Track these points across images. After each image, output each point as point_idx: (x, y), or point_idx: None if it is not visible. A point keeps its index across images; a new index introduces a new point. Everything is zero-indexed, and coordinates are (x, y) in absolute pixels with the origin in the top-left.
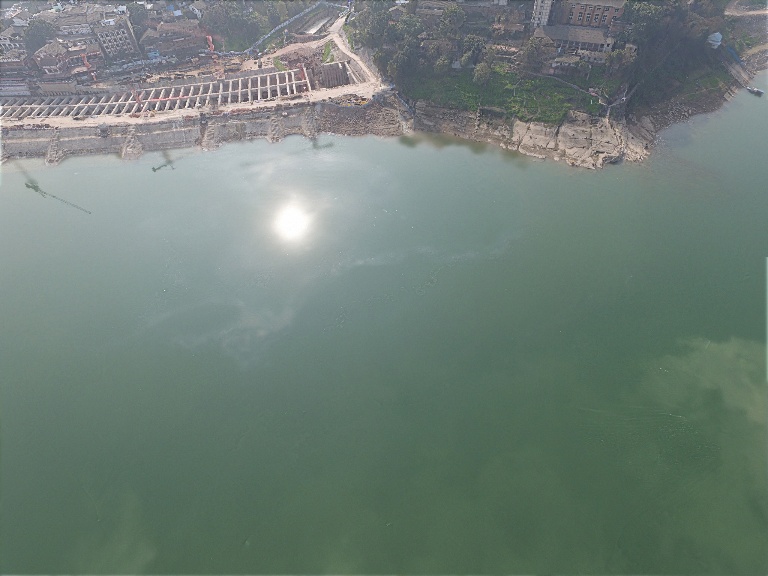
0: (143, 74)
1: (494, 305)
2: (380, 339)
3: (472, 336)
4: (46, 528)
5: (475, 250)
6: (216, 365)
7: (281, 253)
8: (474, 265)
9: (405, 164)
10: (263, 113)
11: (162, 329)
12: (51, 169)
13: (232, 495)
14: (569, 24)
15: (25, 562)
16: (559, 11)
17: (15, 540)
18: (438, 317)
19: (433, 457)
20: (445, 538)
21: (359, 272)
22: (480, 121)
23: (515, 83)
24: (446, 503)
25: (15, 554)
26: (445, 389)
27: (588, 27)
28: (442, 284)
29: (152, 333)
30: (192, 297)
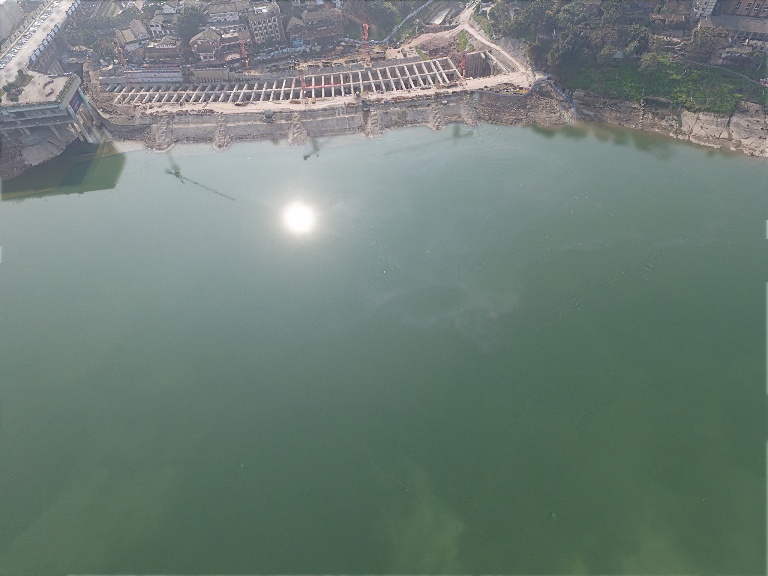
0: (290, 62)
1: (724, 291)
2: (615, 322)
3: (713, 320)
4: (348, 497)
5: (684, 237)
6: (463, 344)
7: (485, 237)
8: (688, 251)
9: (579, 152)
10: (423, 101)
11: (398, 309)
12: (222, 154)
13: (534, 469)
14: (736, 14)
15: (340, 529)
16: (728, 1)
17: (324, 508)
18: (671, 301)
19: (715, 436)
20: (753, 515)
21: (571, 257)
22: (644, 111)
23: (680, 73)
24: (742, 481)
25: (328, 521)
26: (702, 371)
27: (756, 17)
28: (663, 269)
29: (389, 312)
30: (414, 279)
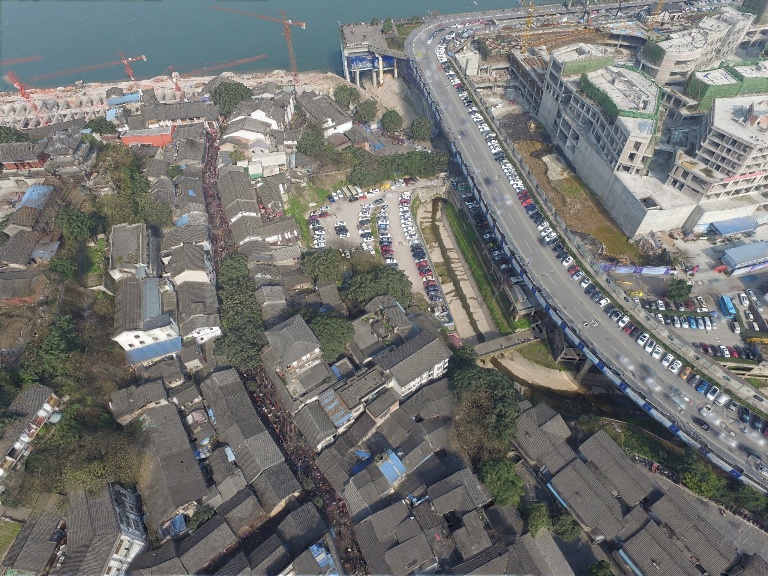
0: None
1: None
2: (41, 15)
3: None
4: None
5: None
6: None
7: (69, 34)
8: None
9: None
10: None
11: (135, 7)
12: (227, 71)
13: None
14: None
15: None
16: None
17: None
18: (8, 16)
19: None
20: None
21: (32, 30)
22: None
23: None
24: None
25: None
26: (27, 4)
27: None
28: None
29: (141, 7)
30: None
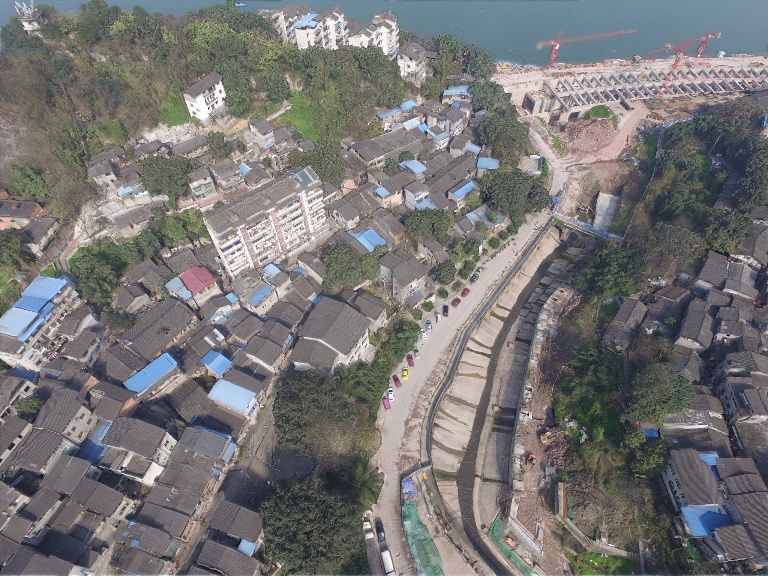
0: None
1: None
2: None
3: None
4: None
5: None
6: None
7: (516, 13)
8: (411, 5)
9: None
10: None
11: None
12: (733, 53)
13: None
14: None
15: None
16: None
17: None
18: None
19: None
20: None
21: (471, 7)
22: None
23: None
24: None
25: None
26: None
27: None
28: None
29: None
30: None
